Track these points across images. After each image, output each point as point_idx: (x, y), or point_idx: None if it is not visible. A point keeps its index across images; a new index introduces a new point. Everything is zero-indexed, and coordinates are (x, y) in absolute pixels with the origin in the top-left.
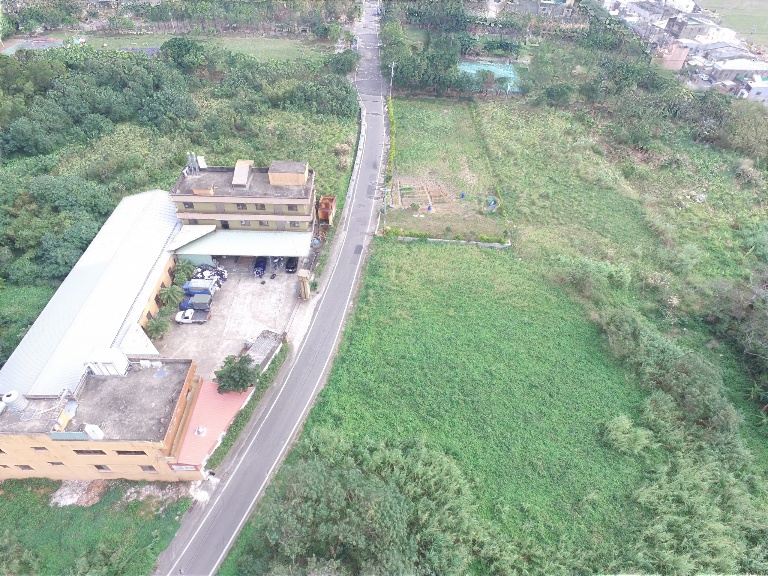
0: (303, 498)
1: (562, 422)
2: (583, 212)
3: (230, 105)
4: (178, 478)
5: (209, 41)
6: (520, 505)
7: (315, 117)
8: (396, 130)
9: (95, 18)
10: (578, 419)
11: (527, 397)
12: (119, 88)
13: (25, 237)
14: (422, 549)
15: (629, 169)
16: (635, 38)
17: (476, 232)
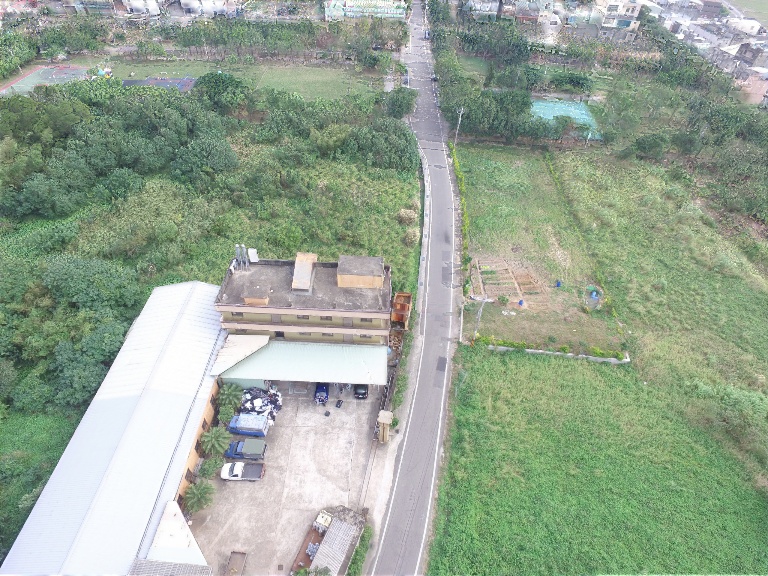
0: None
1: None
2: (710, 312)
3: (273, 154)
4: None
5: (245, 70)
6: None
7: (370, 170)
8: (465, 188)
9: (122, 41)
10: None
11: None
12: (148, 131)
13: (35, 346)
14: None
15: None
16: (705, 66)
17: (583, 339)
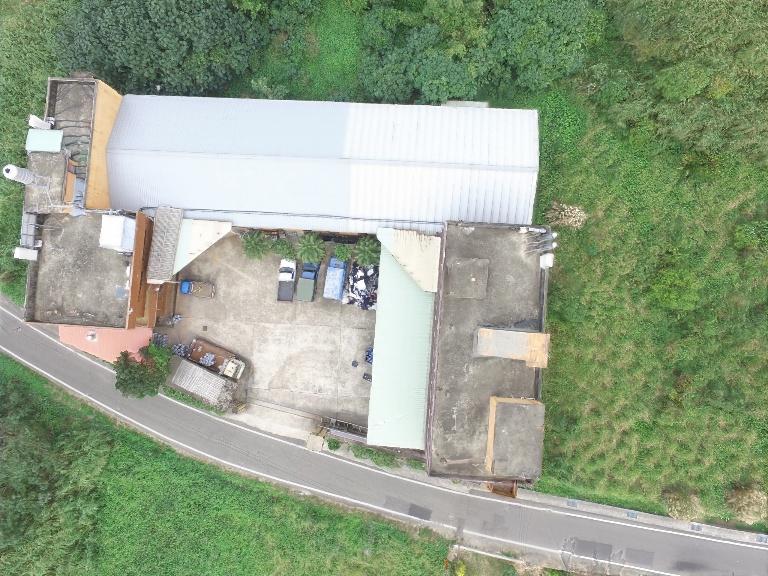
0: None
1: None
2: None
3: None
4: None
5: None
6: None
7: None
8: None
9: None
10: None
11: None
12: None
13: None
14: None
15: None
16: None
17: None
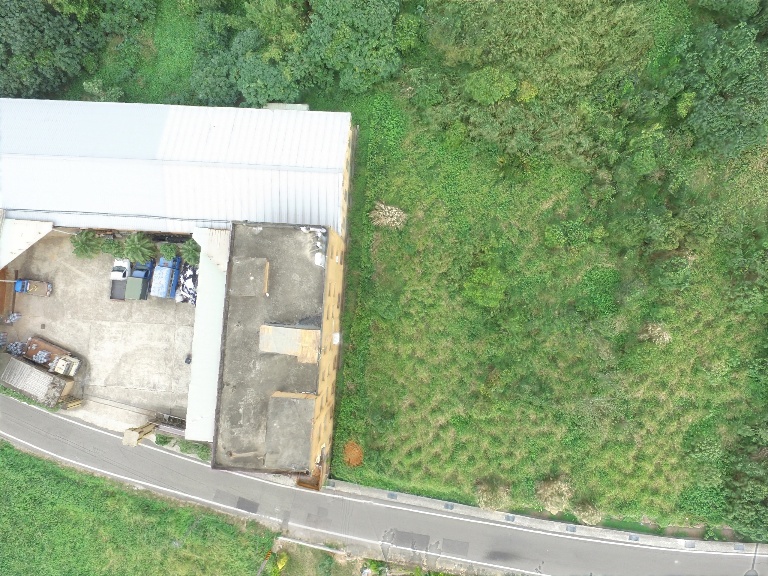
0: None
1: None
2: None
3: None
4: None
5: None
6: None
7: (725, 429)
8: None
9: None
10: None
11: None
12: None
13: (256, 3)
14: None
15: None
16: None
17: None
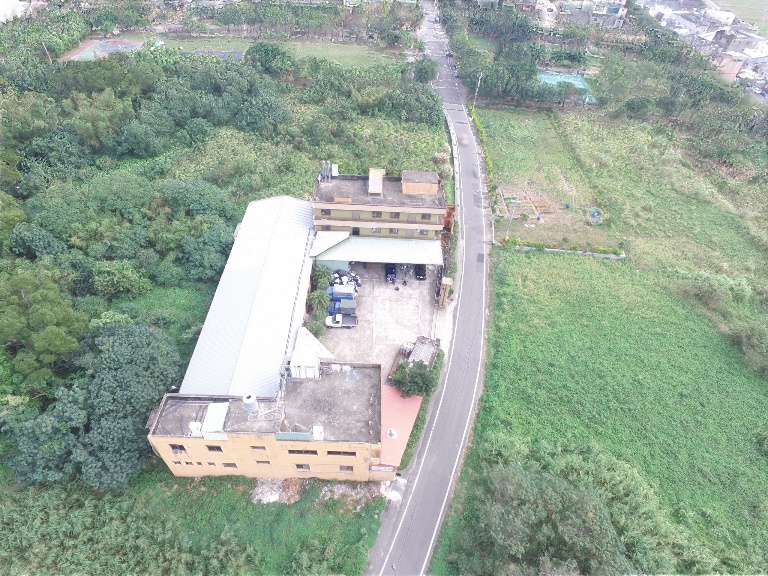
0: (521, 500)
1: (719, 431)
2: (687, 225)
3: (321, 111)
4: (368, 478)
5: (281, 46)
6: (701, 510)
7: (404, 125)
8: (485, 139)
9: (164, 20)
10: (733, 428)
11: (679, 406)
12: (211, 92)
13: (166, 240)
14: (625, 551)
15: (720, 183)
16: (685, 50)
17: None
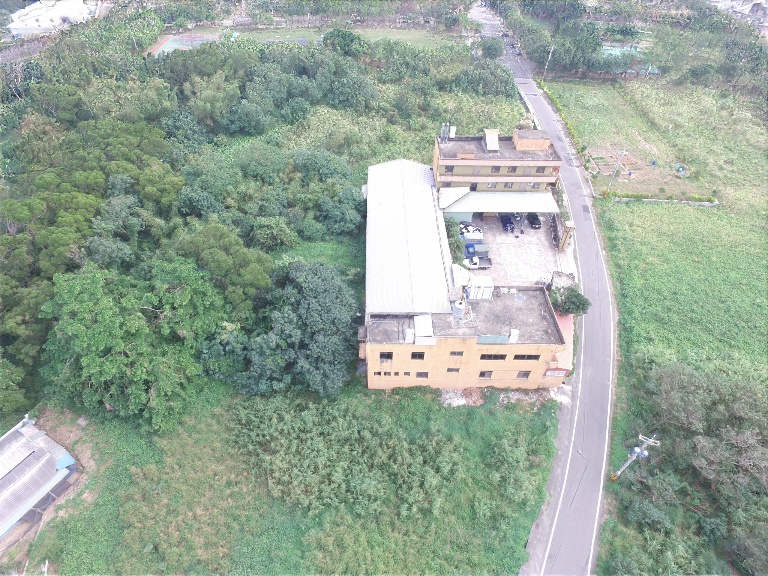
0: (696, 386)
1: None
2: None
3: (402, 89)
4: (538, 385)
5: None
6: None
7: (482, 98)
8: None
9: (228, 14)
10: None
11: None
12: (297, 75)
13: (304, 200)
14: None
15: None
16: None
17: None
